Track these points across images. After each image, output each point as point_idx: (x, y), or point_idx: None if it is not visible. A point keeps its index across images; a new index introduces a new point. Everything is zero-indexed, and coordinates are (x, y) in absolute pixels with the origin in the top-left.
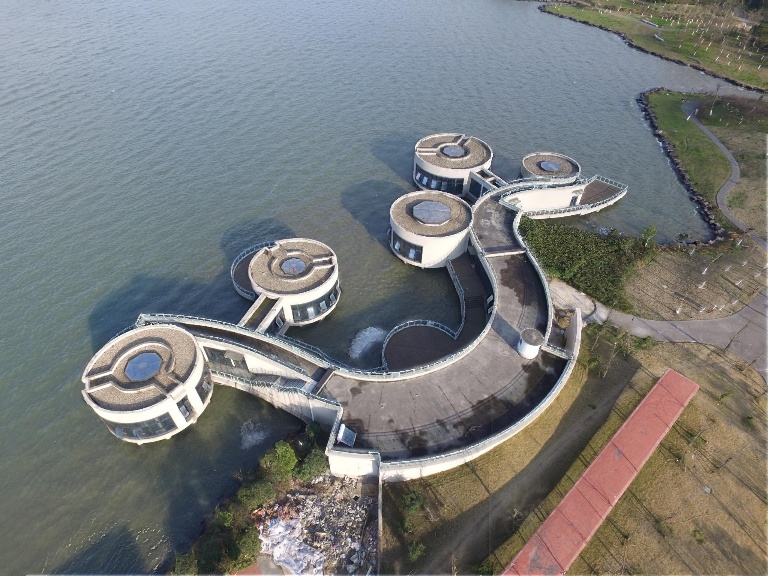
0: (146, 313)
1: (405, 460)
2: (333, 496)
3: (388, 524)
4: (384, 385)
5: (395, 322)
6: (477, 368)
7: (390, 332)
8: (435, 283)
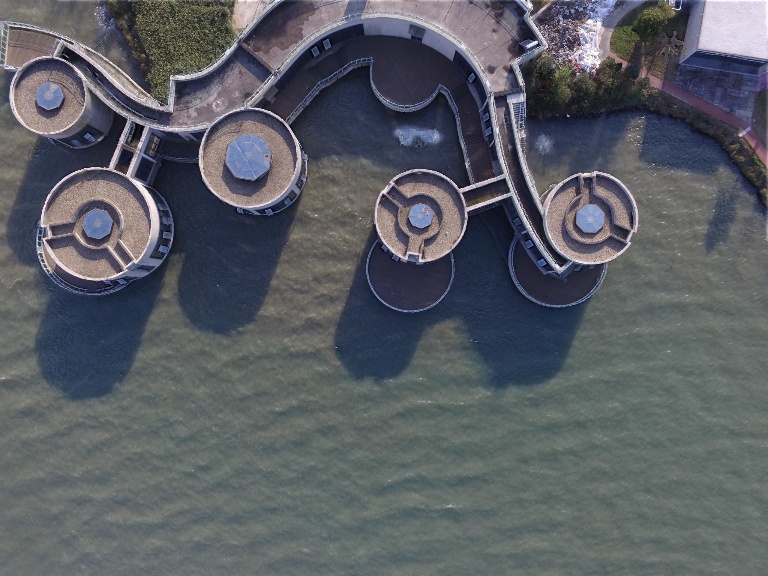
0: (525, 329)
1: (513, 3)
2: (546, 52)
3: (541, 4)
4: (472, 55)
5: (381, 129)
6: (409, 5)
7: (409, 106)
8: (310, 131)
